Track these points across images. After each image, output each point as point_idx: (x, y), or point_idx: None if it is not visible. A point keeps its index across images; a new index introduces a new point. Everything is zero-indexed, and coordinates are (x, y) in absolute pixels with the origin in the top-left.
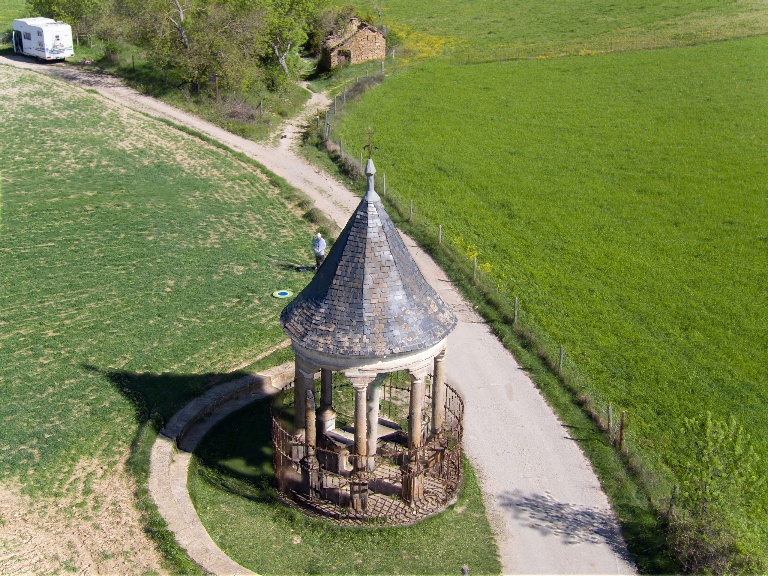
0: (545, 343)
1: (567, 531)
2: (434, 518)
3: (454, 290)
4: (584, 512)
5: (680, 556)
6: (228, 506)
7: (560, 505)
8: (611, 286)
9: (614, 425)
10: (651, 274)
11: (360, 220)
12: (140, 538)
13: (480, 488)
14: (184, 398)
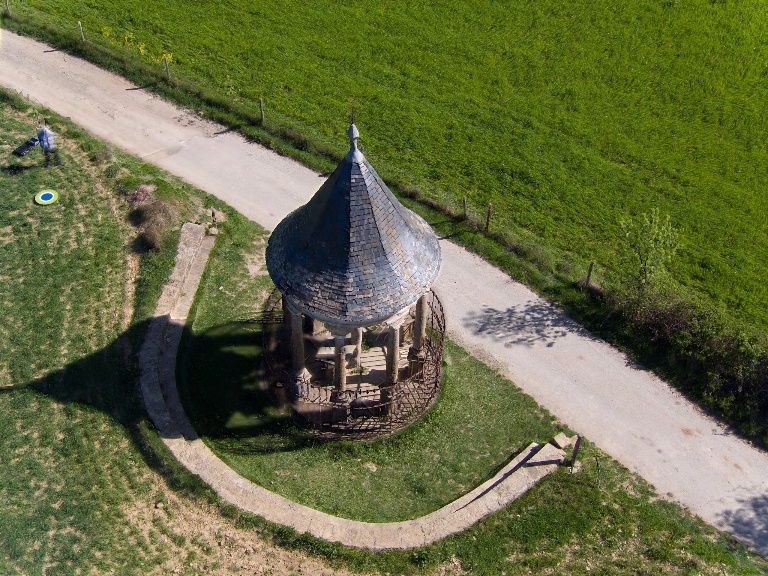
0: (310, 135)
1: (536, 337)
2: (446, 382)
3: (156, 98)
4: (527, 311)
5: (642, 323)
6: (283, 470)
7: (506, 314)
8: (288, 34)
9: (473, 213)
10: (304, 3)
11: (357, 183)
12: (284, 555)
13: (438, 330)
14: (129, 385)
